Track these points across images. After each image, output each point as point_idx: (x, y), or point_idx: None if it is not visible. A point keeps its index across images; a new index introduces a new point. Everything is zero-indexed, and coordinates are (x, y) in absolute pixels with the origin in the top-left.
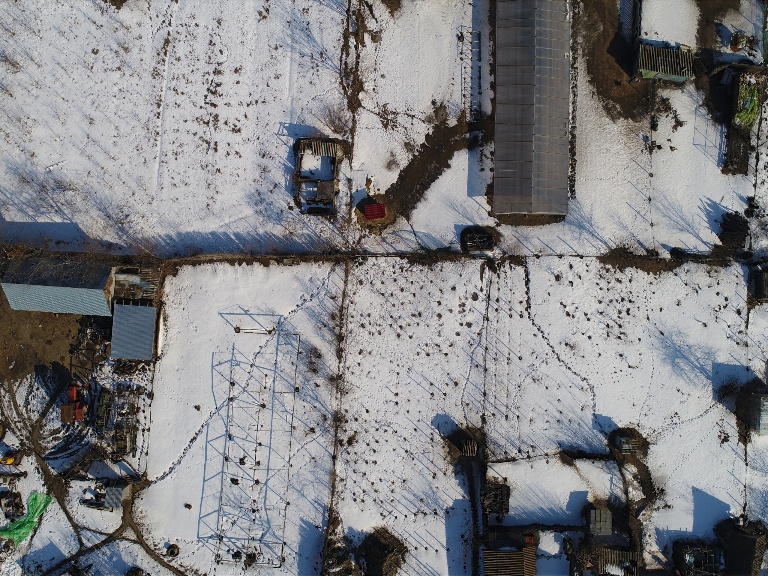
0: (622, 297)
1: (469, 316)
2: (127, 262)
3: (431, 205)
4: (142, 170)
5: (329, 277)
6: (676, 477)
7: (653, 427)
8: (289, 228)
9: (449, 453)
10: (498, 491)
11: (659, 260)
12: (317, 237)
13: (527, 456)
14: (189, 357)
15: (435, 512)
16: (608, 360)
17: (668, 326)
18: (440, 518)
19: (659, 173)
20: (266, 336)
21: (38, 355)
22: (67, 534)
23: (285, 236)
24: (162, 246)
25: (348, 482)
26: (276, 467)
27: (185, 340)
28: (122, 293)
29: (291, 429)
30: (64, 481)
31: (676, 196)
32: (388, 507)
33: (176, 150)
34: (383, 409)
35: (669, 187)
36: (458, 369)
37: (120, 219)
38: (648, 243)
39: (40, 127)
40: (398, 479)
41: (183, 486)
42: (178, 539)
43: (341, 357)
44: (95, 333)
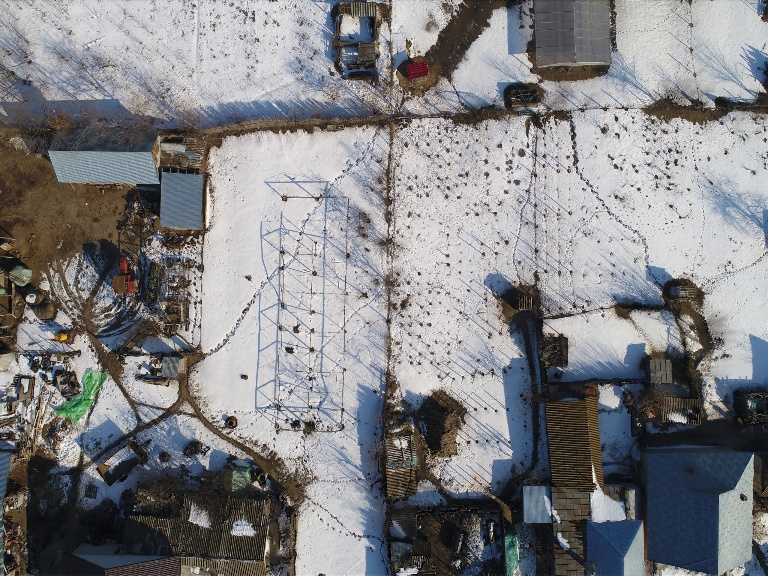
0: (669, 148)
1: (517, 173)
2: (171, 131)
3: (472, 65)
4: (180, 43)
5: (374, 141)
6: (733, 326)
7: (707, 277)
8: (331, 94)
9: (503, 312)
10: (556, 343)
11: (704, 110)
12: (360, 101)
13: (582, 311)
14: (237, 228)
15: (492, 372)
16: (658, 211)
17: (717, 175)
18: (498, 378)
19: (699, 23)
20: (314, 203)
21: (86, 233)
22: (124, 410)
23: (328, 102)
24: (204, 118)
25: (404, 345)
26: (330, 334)
27: (232, 211)
28: (168, 163)
29: (345, 292)
30: (118, 358)
31: (718, 45)
32: (445, 369)
33: (214, 21)
34: (435, 271)
35: (710, 36)
36: (508, 227)
37: (161, 93)
38: (692, 93)
39: (76, 5)
40: (454, 340)
41: (238, 357)
42: (236, 411)
43: (390, 221)
44: (142, 207)
